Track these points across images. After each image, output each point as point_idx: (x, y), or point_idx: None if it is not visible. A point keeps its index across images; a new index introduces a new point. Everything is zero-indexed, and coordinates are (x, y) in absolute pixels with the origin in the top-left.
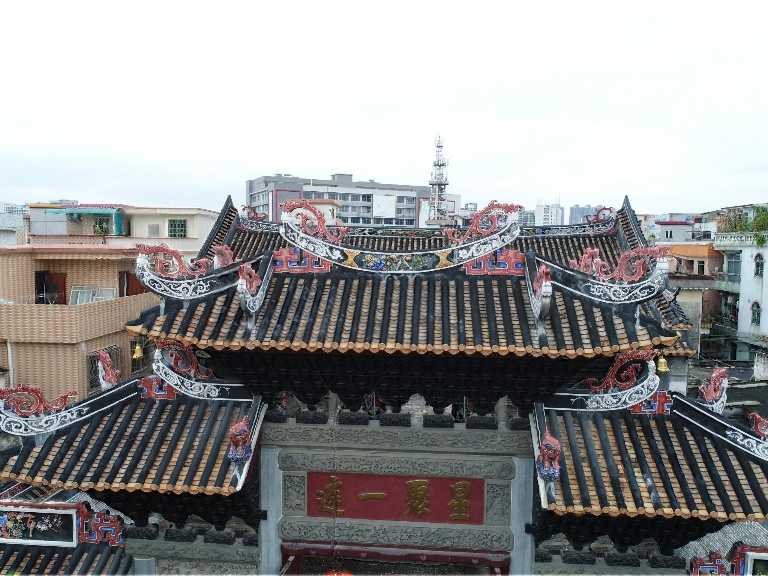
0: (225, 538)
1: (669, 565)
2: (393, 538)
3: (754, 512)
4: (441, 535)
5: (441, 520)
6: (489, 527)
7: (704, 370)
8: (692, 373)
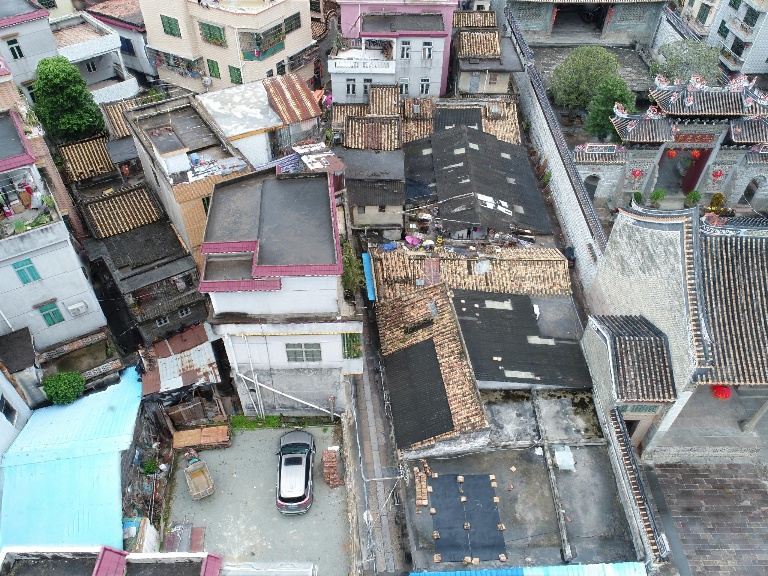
0: None
1: None
2: None
3: None
4: None
5: None
6: None
7: (517, 529)
8: (539, 504)
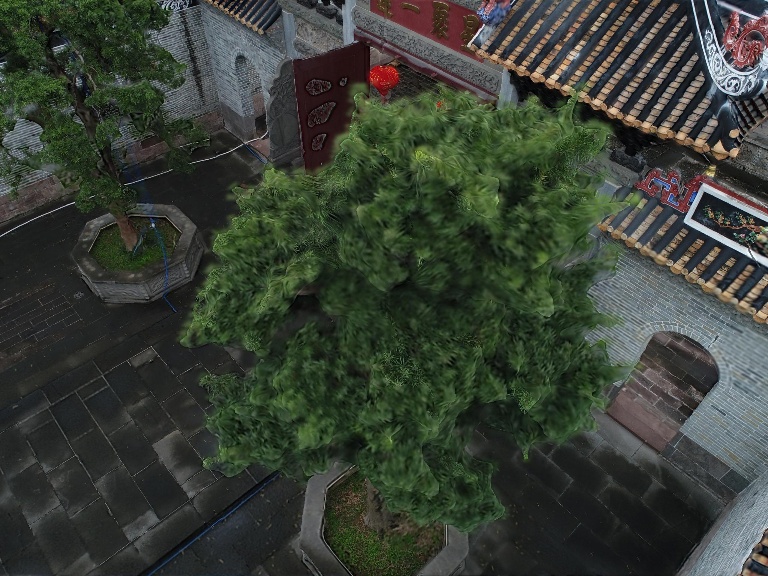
0: (326, 12)
1: (624, 163)
2: (419, 51)
3: (646, 120)
4: (451, 60)
5: (455, 47)
6: (486, 67)
7: None
8: None
